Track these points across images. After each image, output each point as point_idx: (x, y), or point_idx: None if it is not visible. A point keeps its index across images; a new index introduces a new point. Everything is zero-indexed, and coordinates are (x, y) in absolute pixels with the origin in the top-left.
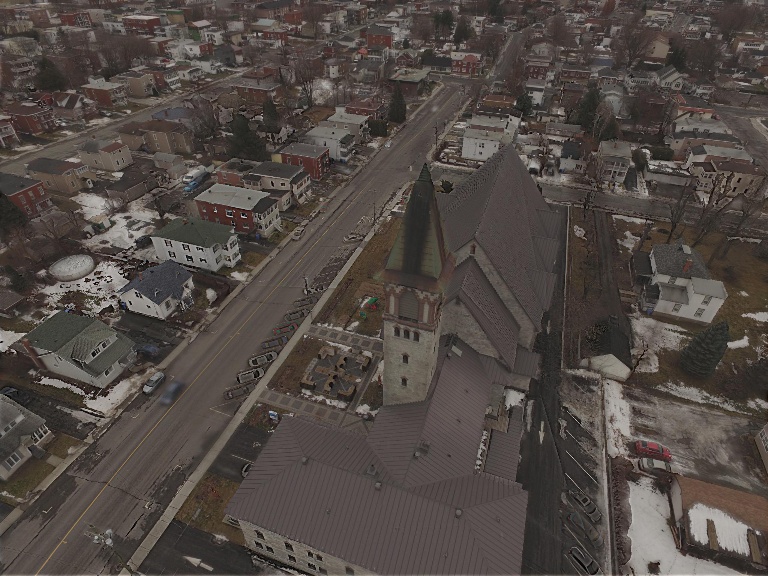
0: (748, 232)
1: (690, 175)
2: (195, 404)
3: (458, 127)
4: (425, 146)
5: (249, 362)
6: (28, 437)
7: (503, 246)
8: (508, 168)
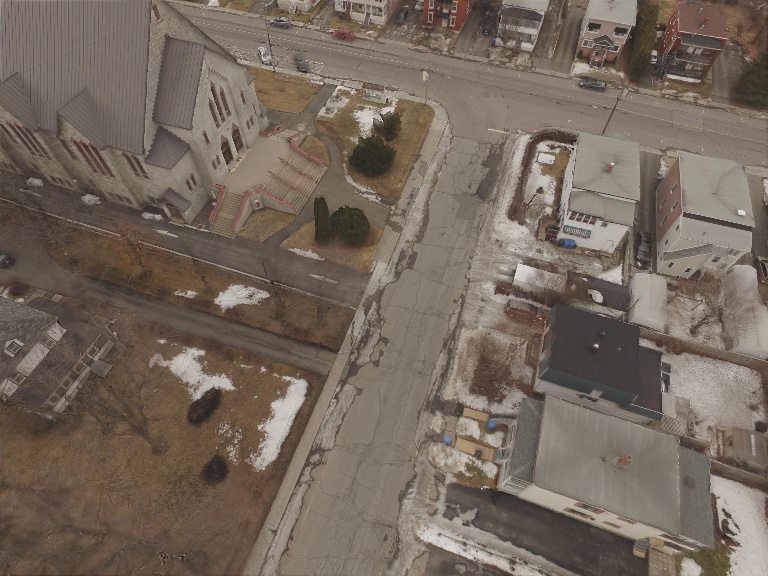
0: None
1: None
2: None
3: (767, 185)
4: (611, 128)
5: None
6: None
7: None
8: None
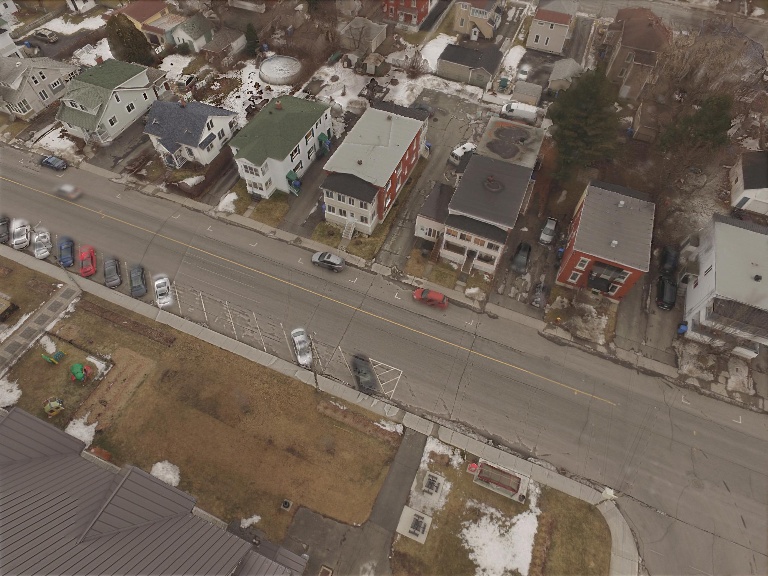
0: None
1: None
2: (6, 198)
3: None
4: None
5: (44, 233)
6: (2, 100)
7: None
8: None
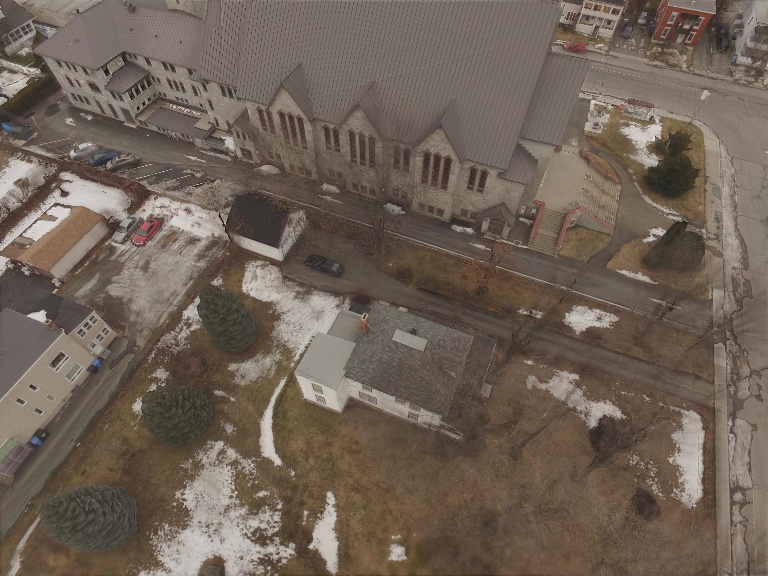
0: None
1: None
2: None
3: None
4: None
5: None
6: None
7: (293, 7)
8: (470, 6)
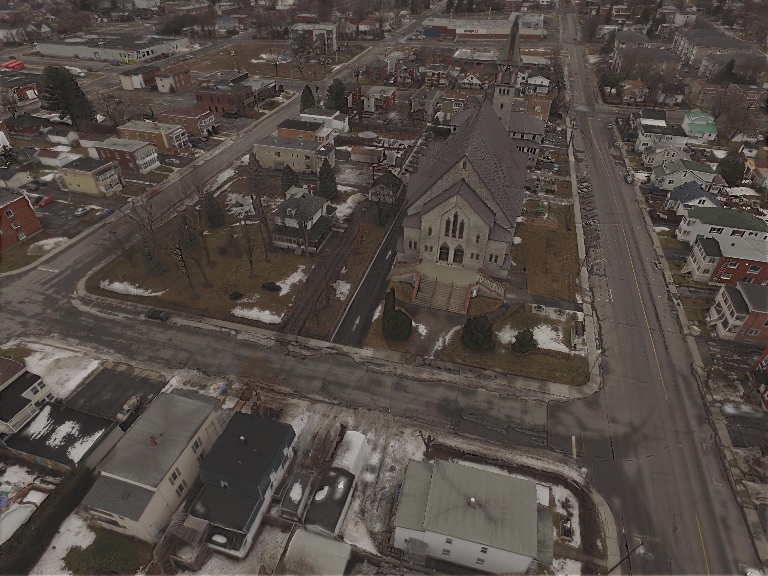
0: (116, 308)
1: (51, 402)
2: None
3: None
4: None
5: None
6: None
7: None
8: None
